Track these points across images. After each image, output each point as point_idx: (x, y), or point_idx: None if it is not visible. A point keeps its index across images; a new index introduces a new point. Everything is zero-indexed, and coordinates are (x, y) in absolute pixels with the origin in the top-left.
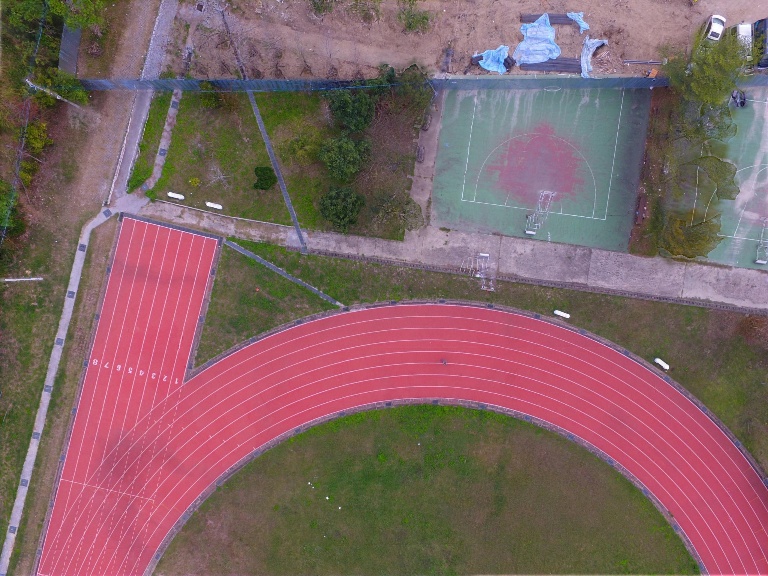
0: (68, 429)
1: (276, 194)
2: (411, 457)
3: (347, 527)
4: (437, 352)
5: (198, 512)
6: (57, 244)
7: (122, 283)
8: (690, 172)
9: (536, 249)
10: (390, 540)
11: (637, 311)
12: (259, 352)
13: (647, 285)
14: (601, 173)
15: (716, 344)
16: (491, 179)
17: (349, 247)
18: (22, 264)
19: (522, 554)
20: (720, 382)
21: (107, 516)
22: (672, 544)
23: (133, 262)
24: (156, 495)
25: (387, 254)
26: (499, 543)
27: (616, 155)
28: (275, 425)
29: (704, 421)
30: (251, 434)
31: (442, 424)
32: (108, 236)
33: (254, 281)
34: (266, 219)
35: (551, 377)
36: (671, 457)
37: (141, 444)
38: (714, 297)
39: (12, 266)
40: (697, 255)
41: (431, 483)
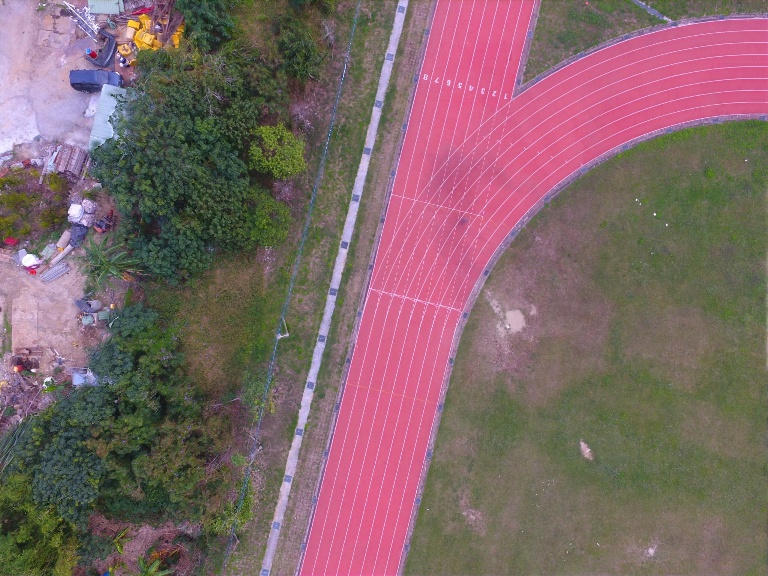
0: (398, 145)
1: None
2: (738, 173)
3: (674, 244)
4: (765, 67)
5: (526, 228)
6: None
7: None
8: None
9: None
10: (717, 257)
11: None
12: (587, 67)
13: None
14: None
15: None
16: None
17: None
18: None
19: None
20: None
21: (437, 232)
22: None
23: None
24: (485, 211)
25: None
26: None
27: None
28: (602, 141)
29: None
30: (579, 150)
31: None
32: None
33: None
34: None
35: None
36: None
37: (470, 160)
38: None
39: None
40: None
41: (758, 199)
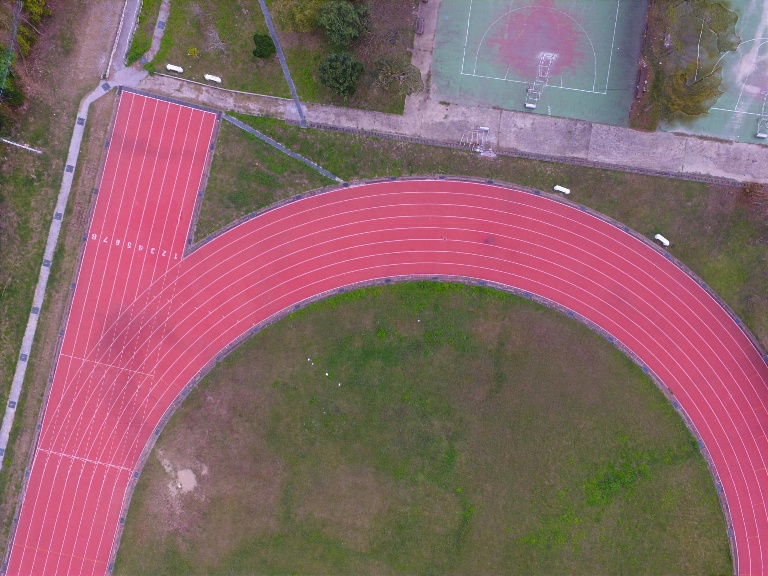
0: (67, 304)
1: (275, 67)
2: (411, 334)
3: (347, 403)
4: (437, 228)
5: (198, 388)
6: (55, 117)
7: (121, 157)
8: (691, 46)
9: (536, 123)
10: (390, 417)
11: (637, 186)
12: (258, 227)
13: (647, 160)
14: (601, 46)
15: (716, 220)
16: (491, 52)
17: (348, 121)
18: (20, 137)
19: (522, 431)
20: (720, 258)
21: (106, 391)
22: (672, 421)
23: (132, 136)
24: (155, 371)
25: (387, 128)
26: (499, 420)
27: (617, 28)
28: (274, 301)
29: (704, 298)
30: (250, 310)
31: (442, 301)
32: (107, 110)
33: (253, 156)
34: (265, 92)
35: (551, 254)
36: (671, 334)
37: (140, 319)
38: (715, 172)
39: (10, 139)
40: (698, 112)
41: (431, 360)
